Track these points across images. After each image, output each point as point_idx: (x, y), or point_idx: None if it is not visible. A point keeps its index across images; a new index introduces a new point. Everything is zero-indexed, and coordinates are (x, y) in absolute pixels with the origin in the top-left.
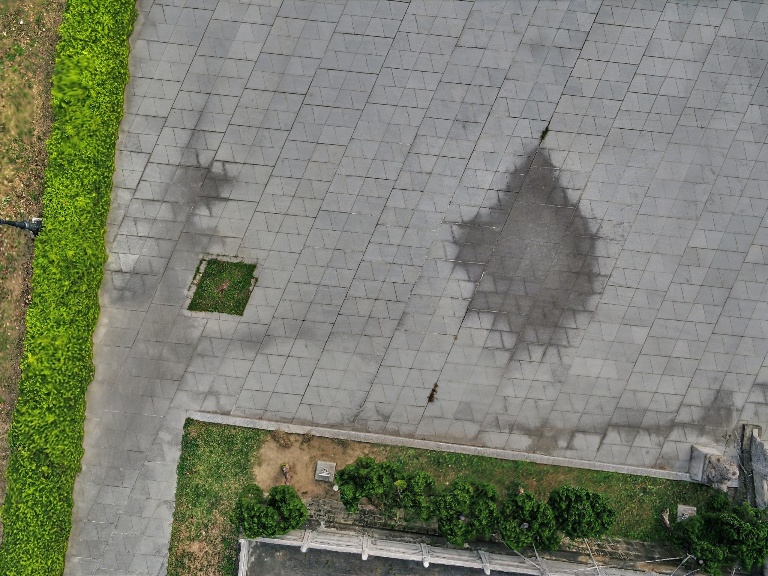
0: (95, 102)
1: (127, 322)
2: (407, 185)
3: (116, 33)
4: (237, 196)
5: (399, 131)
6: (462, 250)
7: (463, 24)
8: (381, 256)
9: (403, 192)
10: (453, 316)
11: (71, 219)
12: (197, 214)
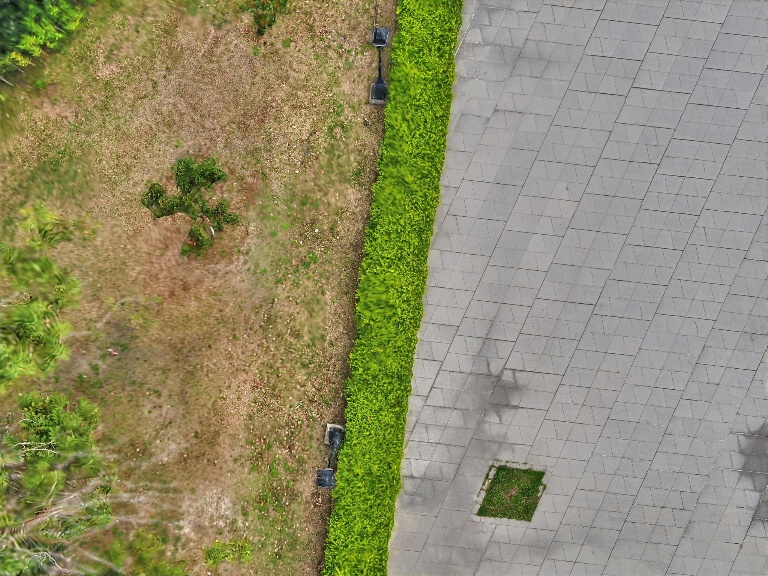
0: (400, 318)
1: (417, 526)
2: (695, 395)
3: (421, 250)
4: (527, 404)
5: (687, 342)
6: (748, 460)
7: (752, 237)
8: (668, 465)
9: (691, 402)
10: (738, 525)
11: (375, 433)
12: (487, 421)
